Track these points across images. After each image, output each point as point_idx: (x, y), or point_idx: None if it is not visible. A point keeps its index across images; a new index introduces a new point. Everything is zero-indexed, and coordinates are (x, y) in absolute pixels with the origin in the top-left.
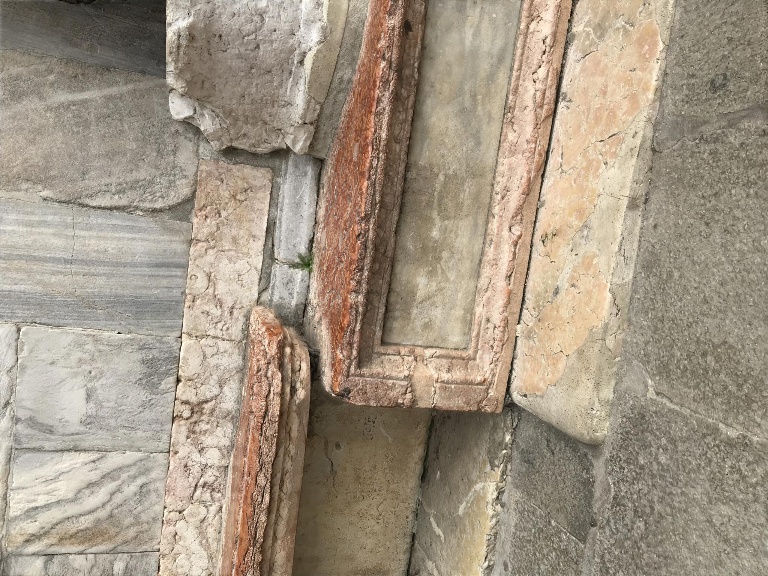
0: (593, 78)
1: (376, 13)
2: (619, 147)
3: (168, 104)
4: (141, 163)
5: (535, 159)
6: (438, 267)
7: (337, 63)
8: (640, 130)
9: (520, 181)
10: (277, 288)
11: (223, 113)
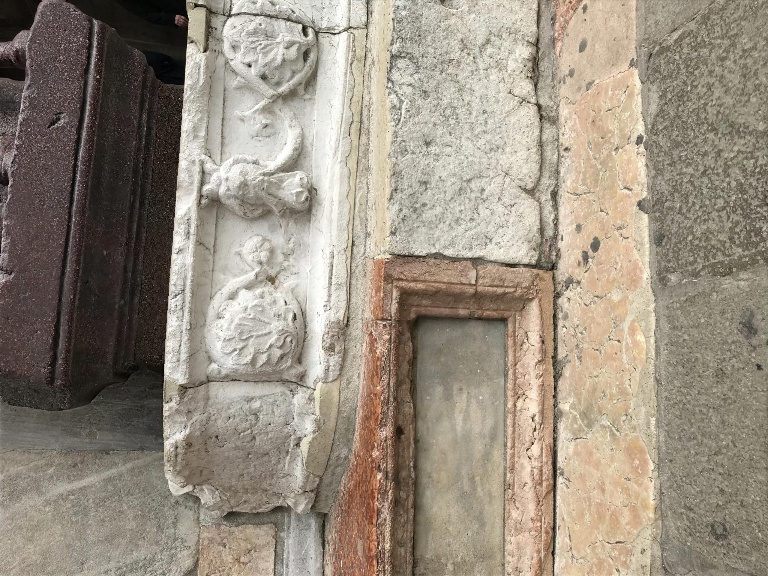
0: (588, 467)
1: (367, 415)
2: (629, 558)
3: None
4: (141, 542)
5: (543, 537)
6: None
7: (333, 445)
8: (647, 548)
9: (531, 562)
10: None
11: (223, 489)
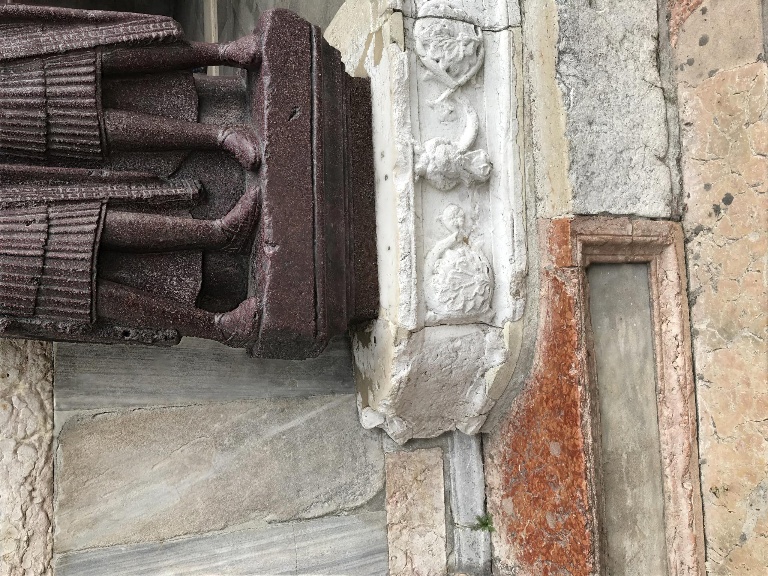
0: (730, 369)
1: (557, 344)
2: None
3: (355, 414)
4: (341, 470)
5: (690, 427)
6: (636, 528)
7: (513, 373)
8: None
9: (683, 446)
10: (464, 551)
11: (412, 419)
